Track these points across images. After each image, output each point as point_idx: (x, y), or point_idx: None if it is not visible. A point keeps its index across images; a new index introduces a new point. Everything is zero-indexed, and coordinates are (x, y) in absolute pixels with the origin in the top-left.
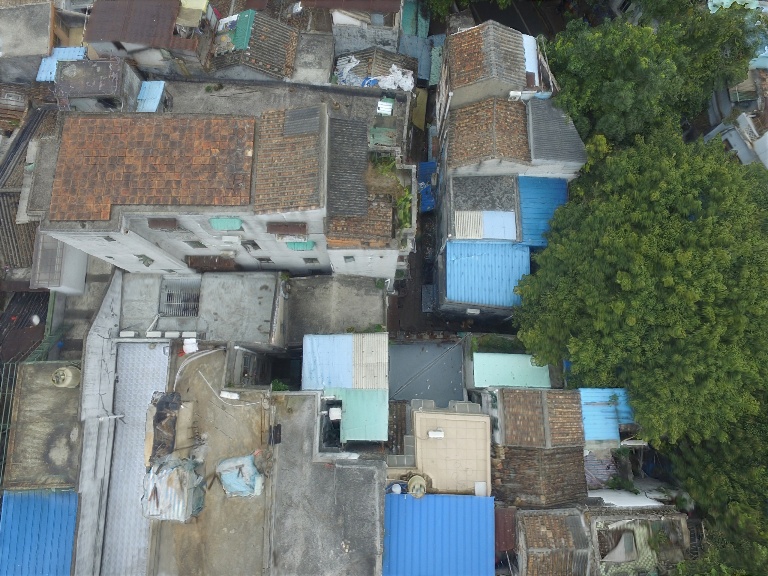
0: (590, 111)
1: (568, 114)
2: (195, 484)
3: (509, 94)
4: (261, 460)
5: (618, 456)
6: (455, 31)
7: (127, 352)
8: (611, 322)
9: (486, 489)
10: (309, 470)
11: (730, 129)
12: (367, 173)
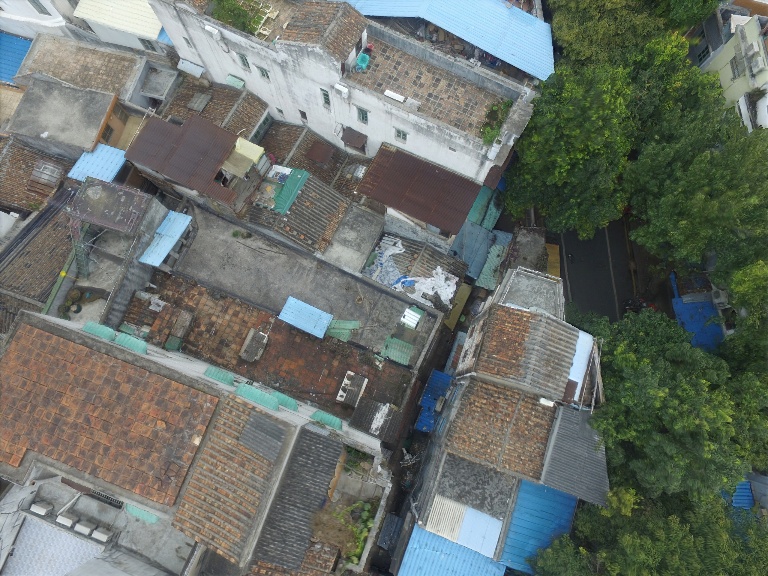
0: (630, 441)
1: (602, 439)
2: None
3: (539, 400)
4: None
5: None
6: (520, 248)
7: (34, 523)
8: None
9: None
10: None
11: None
12: (319, 512)
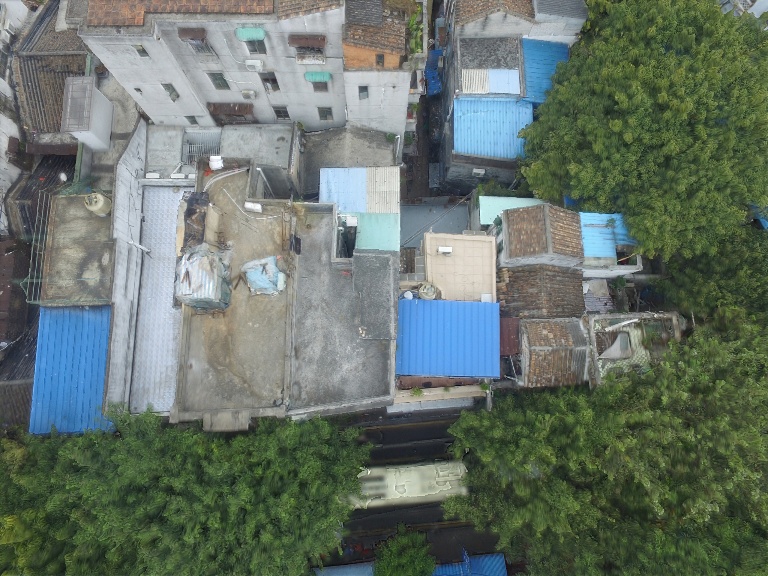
0: None
1: None
2: (223, 274)
3: None
4: (283, 264)
5: (615, 293)
6: None
7: (152, 195)
8: (609, 147)
9: (492, 299)
10: (327, 278)
11: (725, 3)
12: None
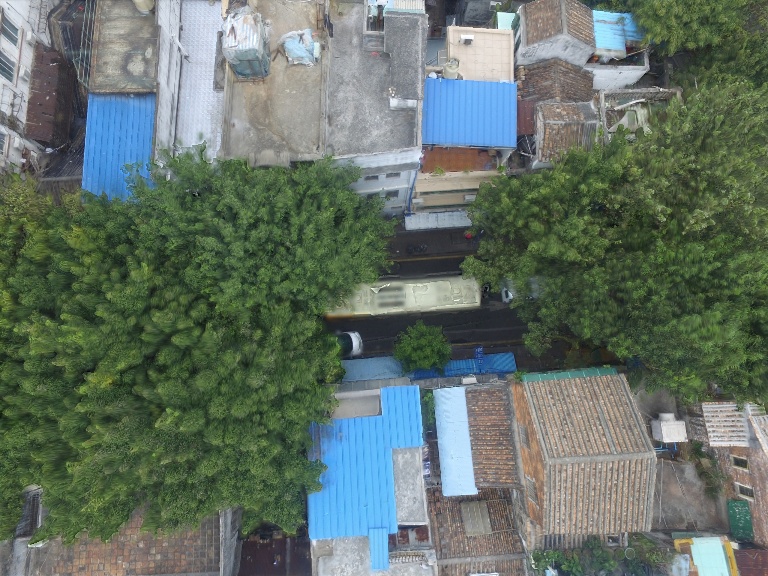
0: None
1: None
2: (264, 36)
3: None
4: (318, 39)
5: None
6: None
7: (189, 7)
8: None
9: None
10: (358, 58)
11: None
12: None
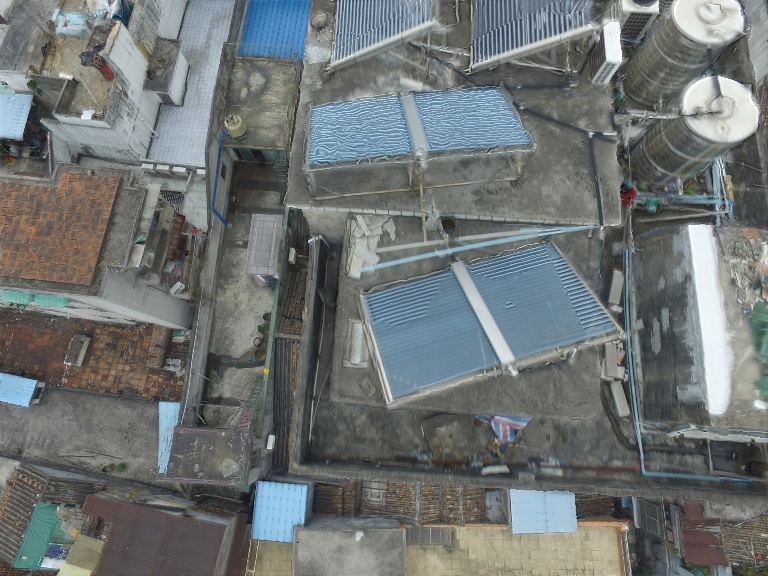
0: None
1: None
2: None
3: None
4: None
5: None
6: None
7: None
8: None
9: None
10: (34, 34)
11: None
12: None
